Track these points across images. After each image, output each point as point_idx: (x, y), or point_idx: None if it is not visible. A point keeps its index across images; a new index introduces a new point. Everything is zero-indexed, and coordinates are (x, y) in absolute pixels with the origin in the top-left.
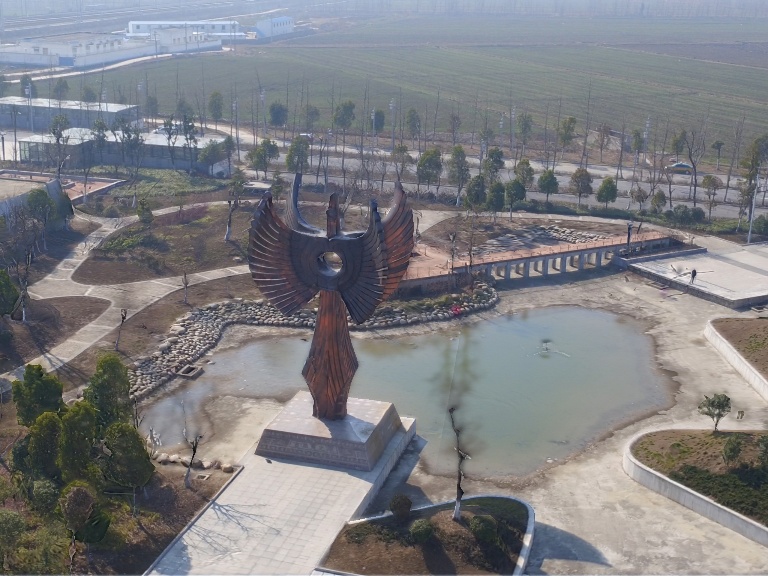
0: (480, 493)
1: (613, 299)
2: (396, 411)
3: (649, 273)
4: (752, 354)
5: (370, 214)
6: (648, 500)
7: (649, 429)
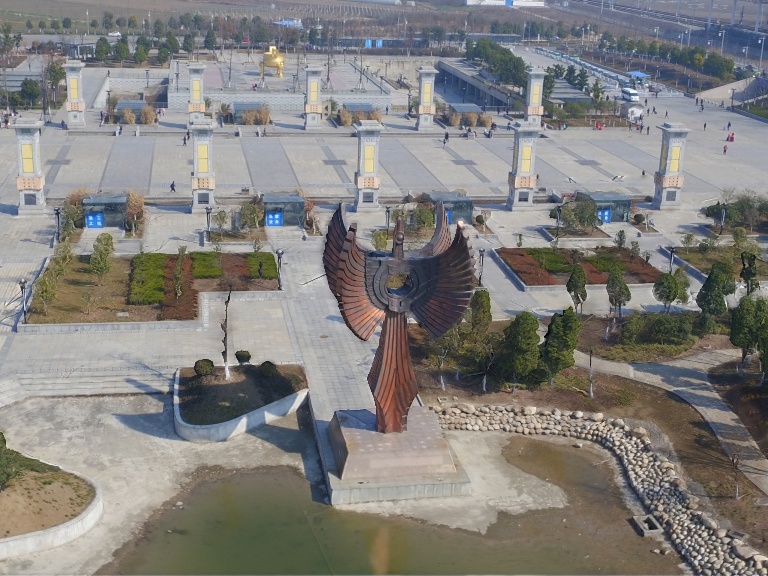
0: (233, 456)
1: None
2: (346, 463)
3: None
4: None
5: None
6: None
7: (69, 571)
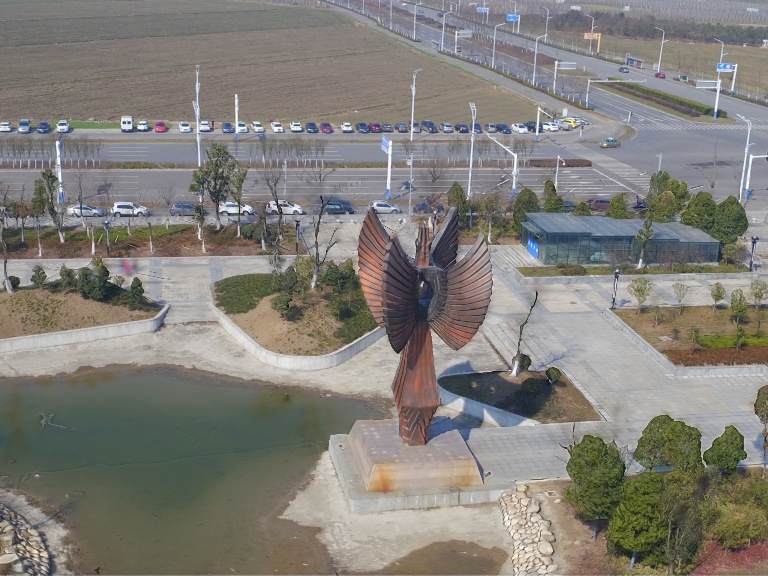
0: None
1: None
2: None
3: None
4: (61, 326)
5: None
6: (365, 360)
7: (233, 368)
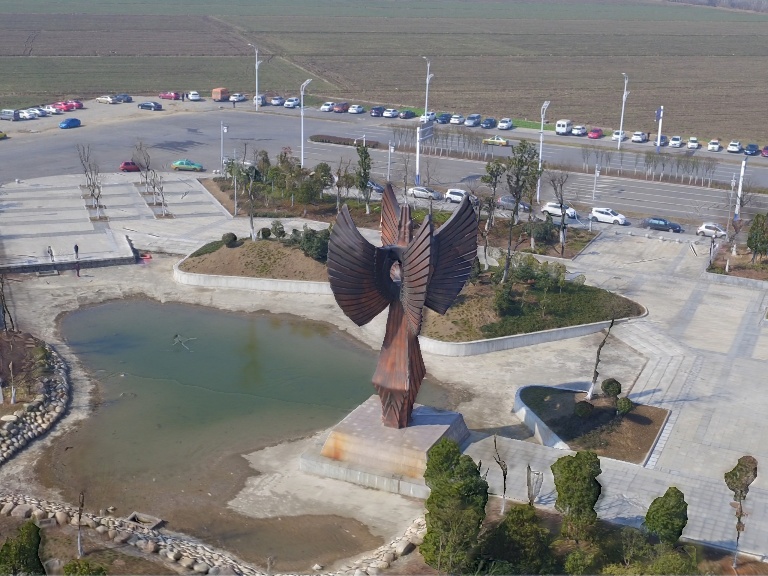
0: (481, 408)
1: (64, 296)
2: None
3: (23, 267)
4: (273, 274)
5: (463, 207)
6: (499, 357)
7: (375, 337)
